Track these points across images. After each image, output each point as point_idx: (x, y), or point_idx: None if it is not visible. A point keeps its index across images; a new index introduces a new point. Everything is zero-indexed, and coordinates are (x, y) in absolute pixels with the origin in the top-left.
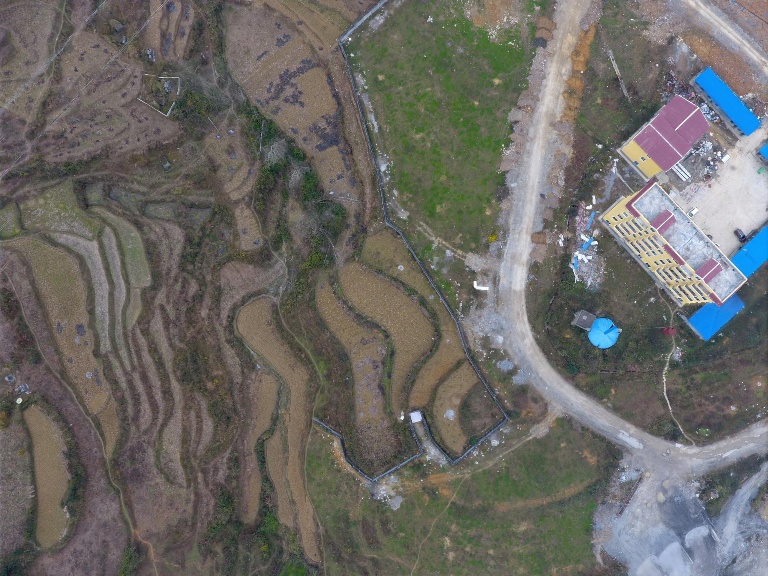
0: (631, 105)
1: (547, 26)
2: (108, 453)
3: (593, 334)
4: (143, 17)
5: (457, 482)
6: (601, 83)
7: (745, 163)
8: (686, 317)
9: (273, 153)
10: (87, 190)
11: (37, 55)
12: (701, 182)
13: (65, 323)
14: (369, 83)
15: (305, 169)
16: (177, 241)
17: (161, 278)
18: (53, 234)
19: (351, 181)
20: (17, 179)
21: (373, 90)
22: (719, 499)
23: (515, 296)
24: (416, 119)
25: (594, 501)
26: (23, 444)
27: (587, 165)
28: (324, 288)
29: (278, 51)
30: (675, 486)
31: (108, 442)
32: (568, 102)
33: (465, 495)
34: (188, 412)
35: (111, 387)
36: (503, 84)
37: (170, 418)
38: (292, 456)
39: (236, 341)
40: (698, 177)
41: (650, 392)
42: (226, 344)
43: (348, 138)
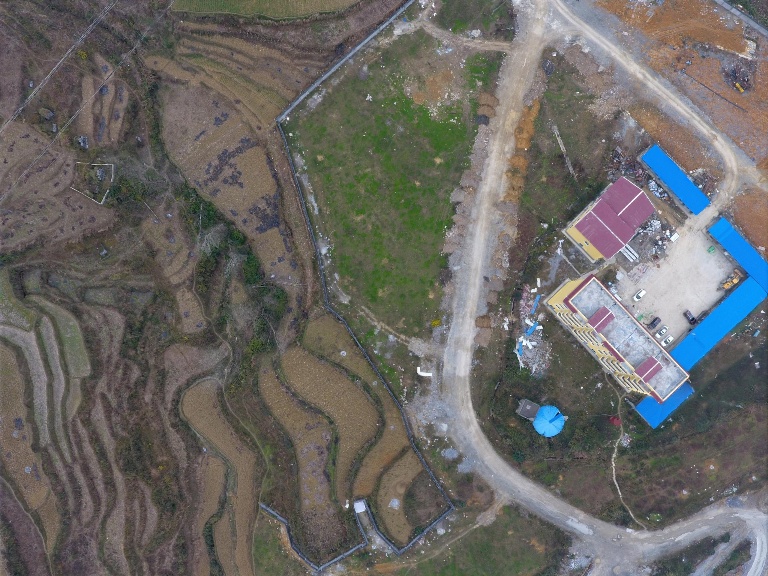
0: (577, 183)
1: (489, 103)
2: (49, 548)
3: (538, 422)
4: (75, 103)
5: (403, 571)
6: (546, 160)
7: (695, 241)
8: (633, 404)
9: (206, 245)
10: (25, 278)
11: None
12: (649, 262)
13: (3, 417)
14: (308, 164)
15: (242, 257)
16: (117, 327)
17: (101, 366)
18: None
19: (292, 263)
20: None
21: (312, 171)
22: None
23: (459, 382)
24: (356, 201)
25: None
26: None
27: (532, 245)
28: (267, 373)
29: (216, 130)
30: (626, 572)
31: (49, 537)
32: (512, 181)
33: None
34: (131, 502)
35: (50, 482)
36: (445, 163)
37: (113, 509)
38: (240, 540)
39: (181, 425)
40: (646, 257)
41: (599, 477)
42: (171, 428)
43: (288, 220)
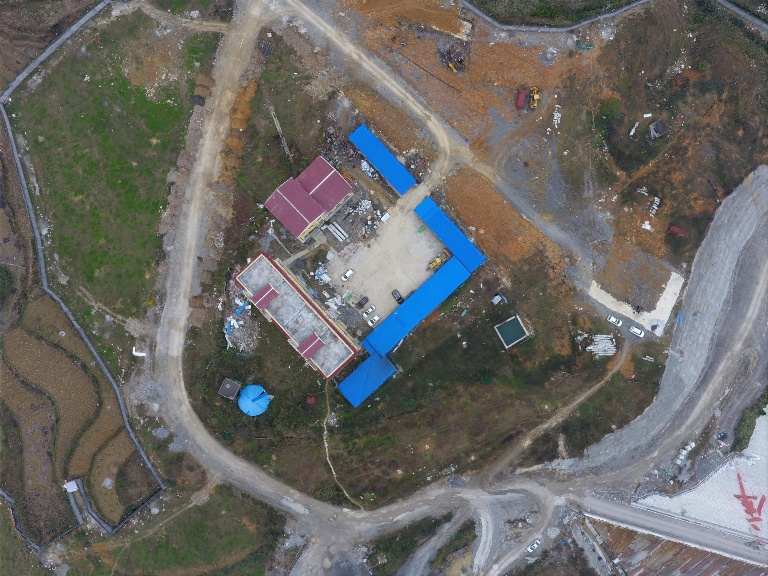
0: (291, 163)
1: (204, 83)
2: None
3: (242, 401)
4: None
5: (118, 551)
6: (262, 141)
7: (406, 221)
8: (337, 383)
9: None
10: None
11: None
12: (360, 242)
13: None
14: (30, 144)
15: None
16: None
17: None
18: None
19: (18, 244)
20: None
21: (34, 152)
22: (386, 564)
23: (172, 362)
24: (75, 181)
25: (261, 567)
26: None
27: None
28: None
29: None
30: (342, 551)
31: None
32: (225, 162)
33: (125, 564)
34: None
35: None
36: (161, 144)
37: None
38: None
39: None
40: (357, 237)
41: (314, 457)
42: None
43: (11, 201)
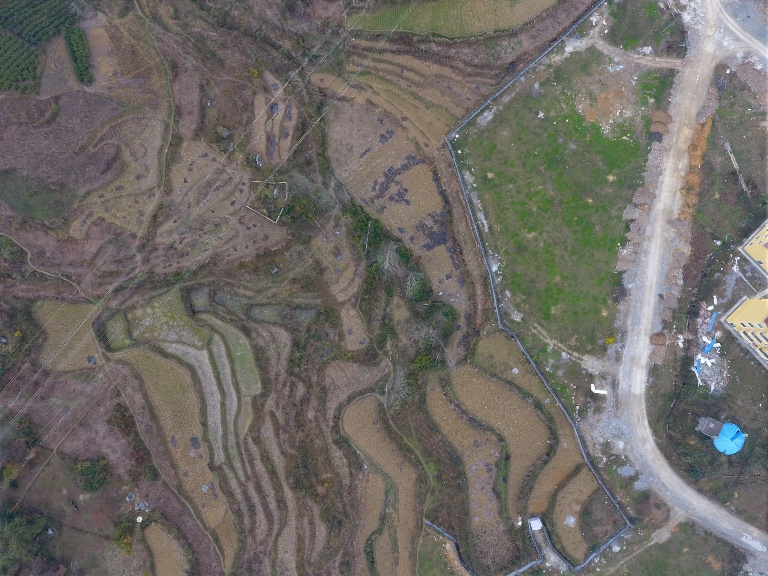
0: (751, 200)
1: (663, 120)
2: (227, 567)
3: (719, 440)
4: (248, 121)
5: None
6: (719, 177)
7: None
8: None
9: (390, 264)
10: (193, 296)
11: (147, 169)
12: None
13: (179, 436)
14: (478, 181)
15: (419, 275)
16: (284, 345)
17: (270, 384)
18: (162, 344)
19: (460, 281)
20: (126, 291)
21: (482, 188)
22: None
23: (635, 400)
24: (528, 218)
25: None
26: (145, 564)
27: (706, 263)
28: (435, 390)
29: (381, 148)
30: None
31: (227, 556)
32: (686, 199)
33: None
34: (301, 519)
35: (228, 500)
36: (618, 181)
37: (284, 526)
38: (402, 557)
39: (343, 442)
40: None
41: None
42: (333, 445)
43: (457, 238)
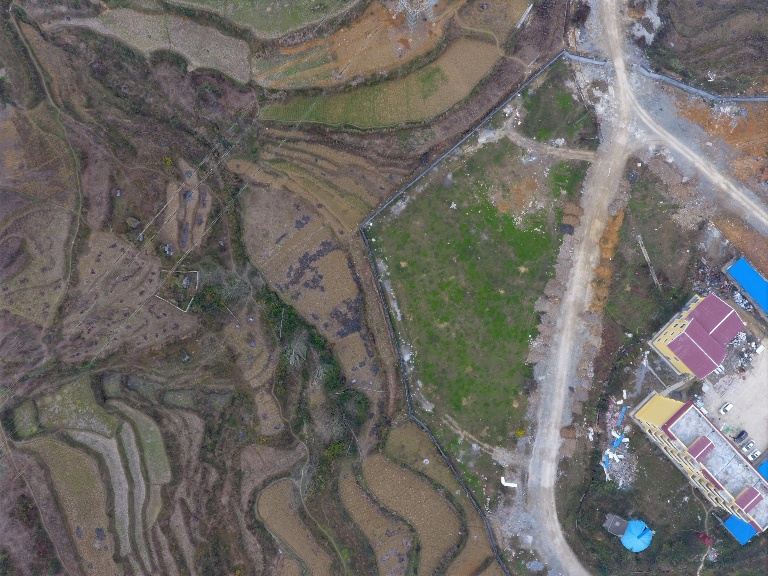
0: (662, 293)
1: (574, 212)
2: None
3: (626, 537)
4: None
5: None
6: (630, 270)
7: None
8: (722, 519)
9: (295, 359)
10: (104, 382)
11: (53, 261)
12: (735, 374)
13: (84, 527)
14: (391, 270)
15: (328, 367)
16: (197, 431)
17: (181, 472)
18: (71, 432)
19: (374, 368)
20: (34, 379)
21: (395, 277)
22: None
23: (544, 493)
24: (440, 308)
25: None
26: None
27: (617, 355)
28: (347, 478)
29: (297, 233)
30: None
31: None
32: (597, 291)
33: None
34: None
35: None
36: (529, 272)
37: None
38: None
39: (257, 528)
40: (732, 369)
41: None
42: (247, 531)
43: (370, 326)
